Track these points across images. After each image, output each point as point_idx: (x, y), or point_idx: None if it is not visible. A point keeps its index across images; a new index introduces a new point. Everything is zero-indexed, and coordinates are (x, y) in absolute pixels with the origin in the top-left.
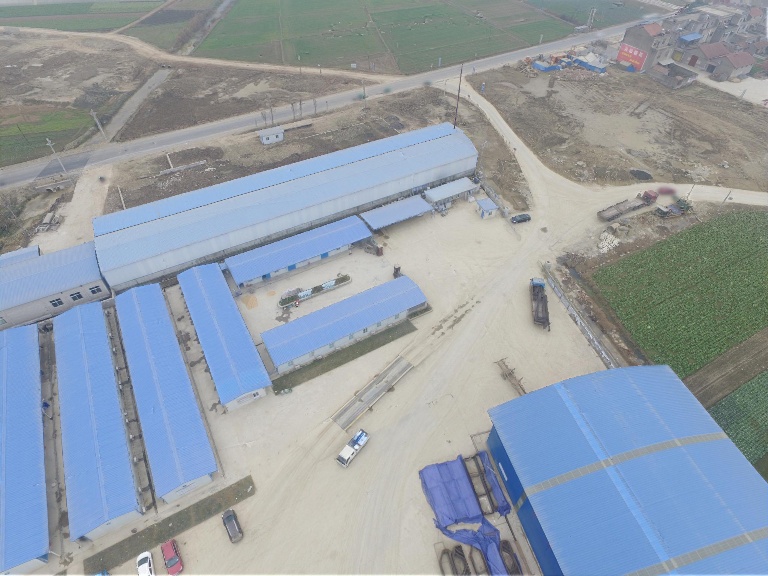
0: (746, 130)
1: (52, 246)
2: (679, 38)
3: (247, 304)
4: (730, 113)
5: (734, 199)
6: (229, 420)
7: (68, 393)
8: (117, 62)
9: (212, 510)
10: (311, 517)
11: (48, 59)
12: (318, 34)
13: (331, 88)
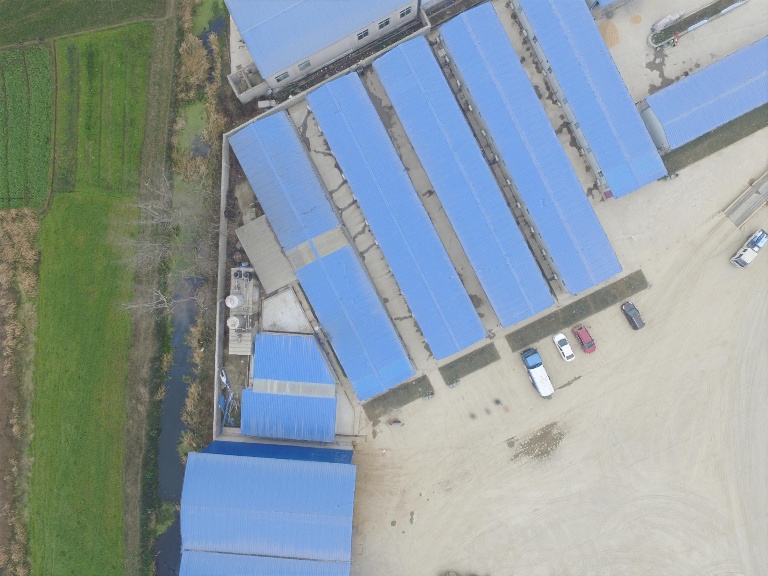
0: None
1: None
2: None
3: (605, 38)
4: None
5: None
6: (610, 209)
7: (439, 177)
8: None
9: (609, 300)
10: (703, 311)
11: None
12: None
13: None
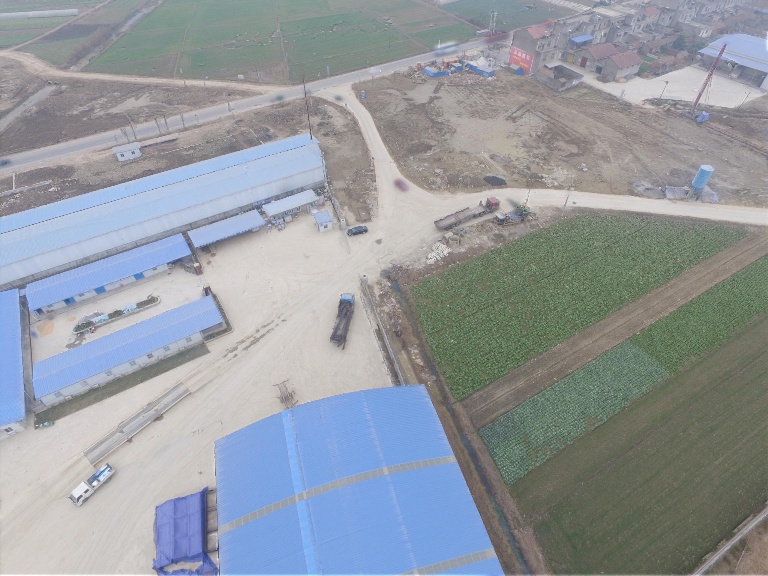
0: (617, 131)
1: None
2: (570, 40)
3: (41, 331)
4: (607, 114)
5: (581, 203)
6: None
7: None
8: (2, 80)
9: None
10: (23, 563)
11: None
12: (219, 45)
13: (212, 100)
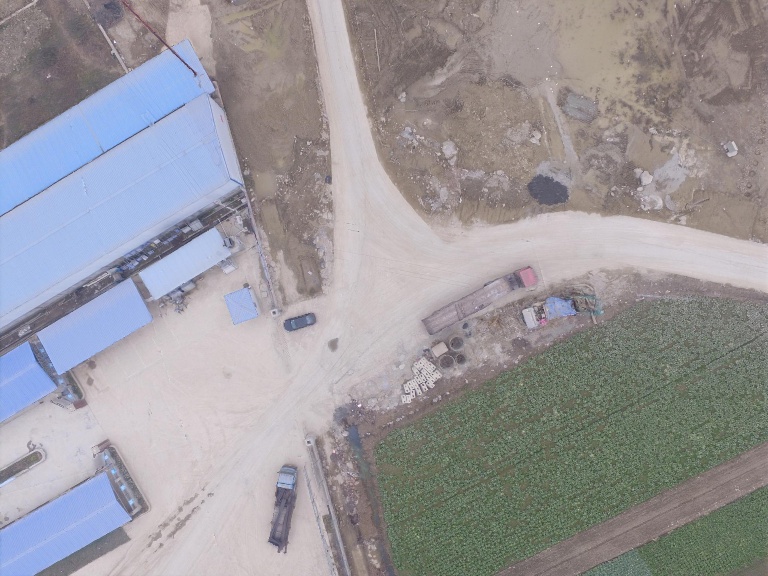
0: None
1: None
2: None
3: None
4: None
5: (684, 264)
6: None
7: None
8: None
9: None
10: None
11: None
12: None
13: None
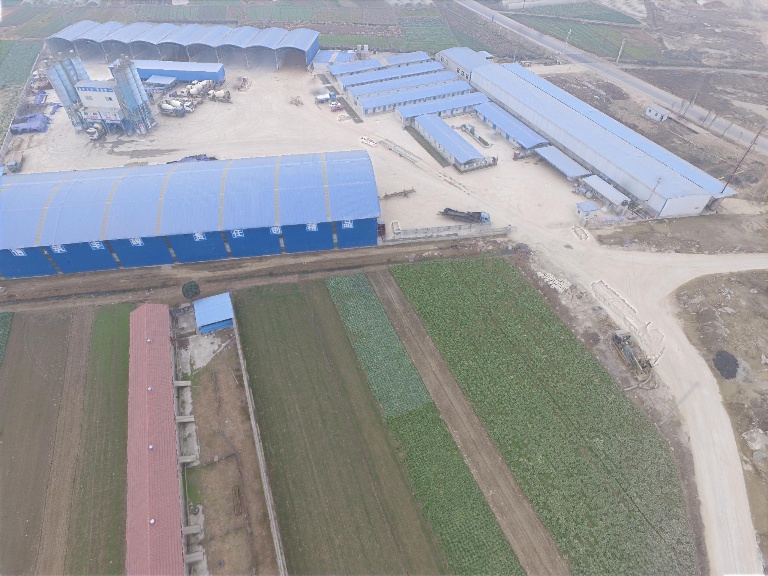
0: None
1: None
2: None
3: (464, 117)
4: None
5: (704, 462)
6: (391, 116)
7: None
8: (755, 53)
9: None
10: None
11: (731, 31)
12: None
13: None
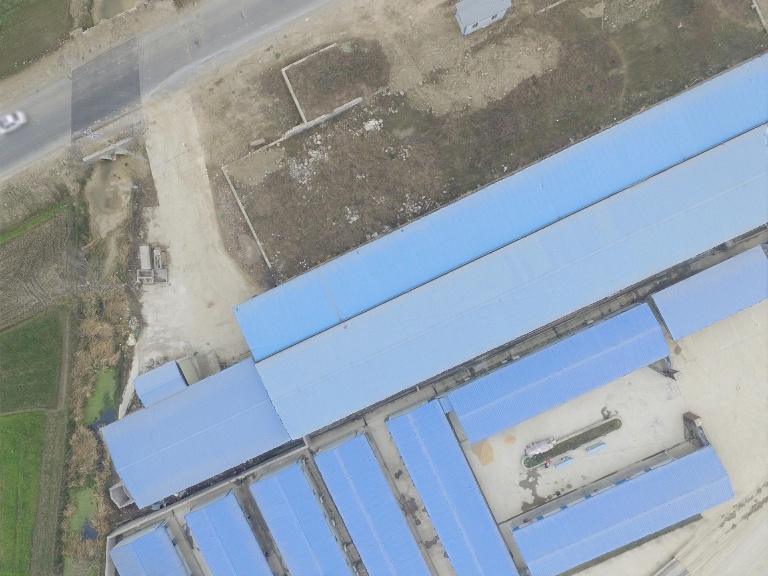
0: None
1: (178, 319)
2: None
3: (480, 456)
4: None
5: None
6: None
7: None
8: None
9: None
10: None
11: None
12: None
13: None
